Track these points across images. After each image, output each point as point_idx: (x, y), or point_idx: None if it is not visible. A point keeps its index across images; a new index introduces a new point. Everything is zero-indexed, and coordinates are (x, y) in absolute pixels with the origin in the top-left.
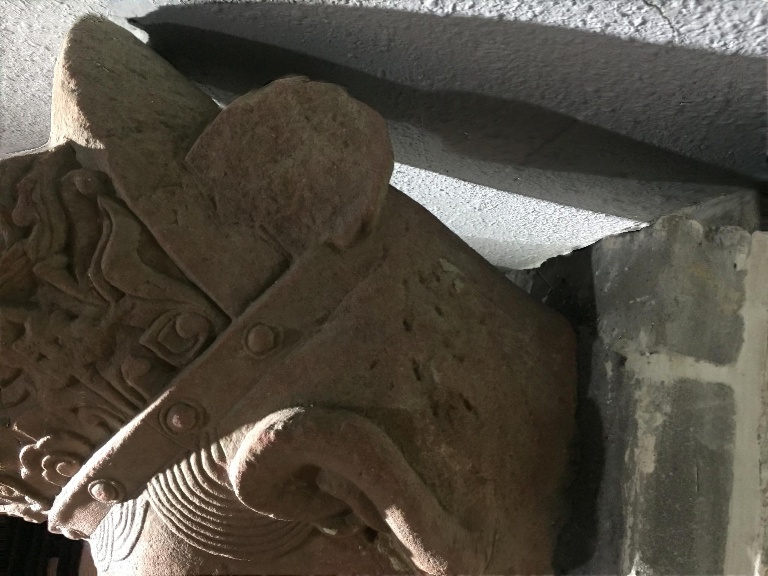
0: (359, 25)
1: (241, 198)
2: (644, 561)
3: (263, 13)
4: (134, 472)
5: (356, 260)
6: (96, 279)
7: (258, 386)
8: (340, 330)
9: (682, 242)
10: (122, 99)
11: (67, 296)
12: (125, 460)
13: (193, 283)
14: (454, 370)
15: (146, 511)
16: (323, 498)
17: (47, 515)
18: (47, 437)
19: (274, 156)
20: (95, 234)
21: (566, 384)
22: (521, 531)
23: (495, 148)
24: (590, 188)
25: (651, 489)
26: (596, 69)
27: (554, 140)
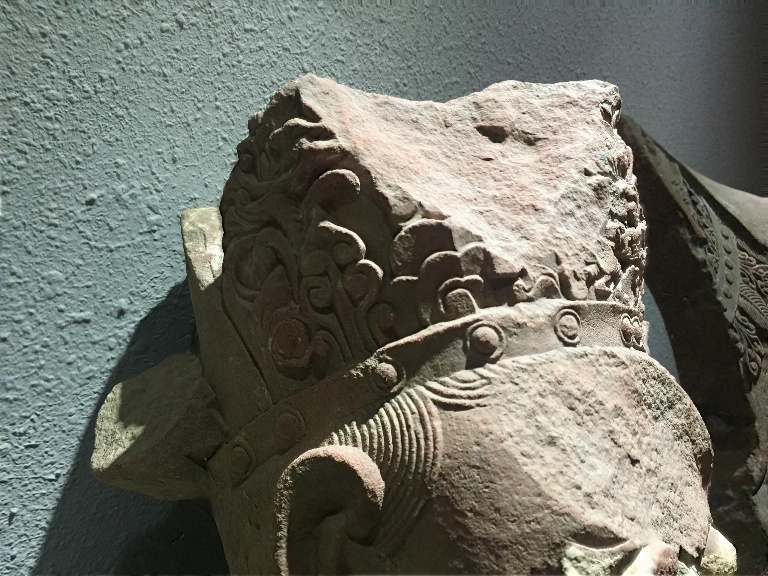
0: None
1: None
2: None
3: None
4: None
5: None
6: None
7: None
8: None
9: None
10: None
11: None
12: None
13: None
14: None
15: None
16: None
17: None
18: None
19: None
20: None
21: None
22: None
23: None
24: None
25: None
26: None
27: None
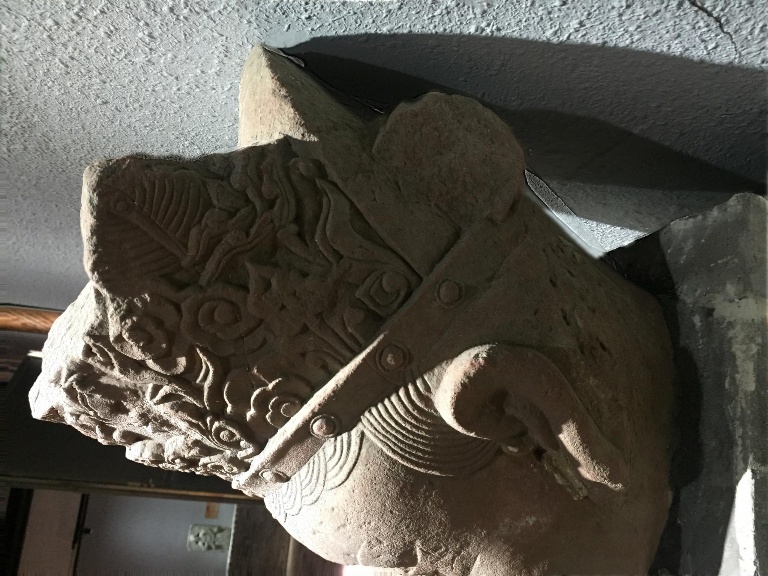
0: (482, 52)
1: (419, 182)
2: (756, 461)
3: (403, 43)
4: (351, 407)
5: (508, 232)
6: (323, 243)
7: (450, 330)
8: (507, 285)
9: (754, 212)
10: (318, 105)
11: (300, 258)
12: (345, 396)
13: (391, 249)
14: (591, 318)
15: (362, 440)
16: (508, 420)
17: (249, 463)
18: (279, 379)
19: (439, 150)
20: (317, 208)
21: (663, 336)
22: (647, 453)
23: (550, 164)
24: (617, 201)
25: (755, 403)
26: (664, 87)
27: (605, 154)
